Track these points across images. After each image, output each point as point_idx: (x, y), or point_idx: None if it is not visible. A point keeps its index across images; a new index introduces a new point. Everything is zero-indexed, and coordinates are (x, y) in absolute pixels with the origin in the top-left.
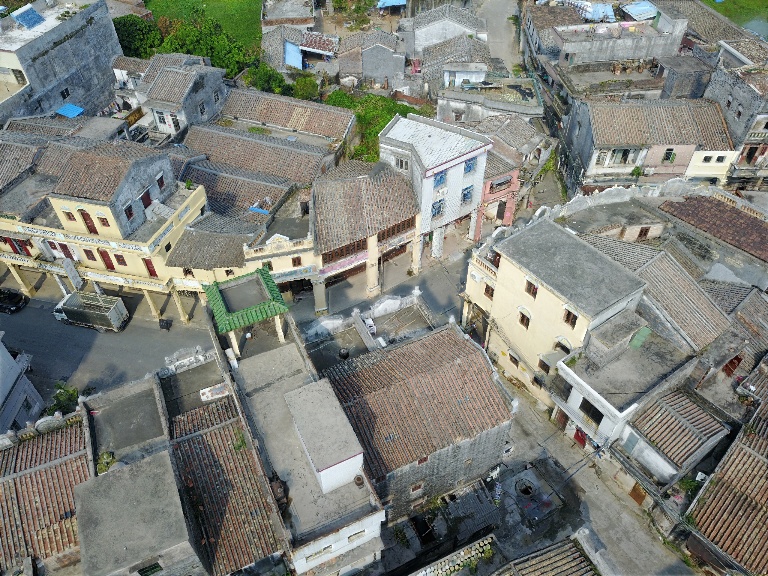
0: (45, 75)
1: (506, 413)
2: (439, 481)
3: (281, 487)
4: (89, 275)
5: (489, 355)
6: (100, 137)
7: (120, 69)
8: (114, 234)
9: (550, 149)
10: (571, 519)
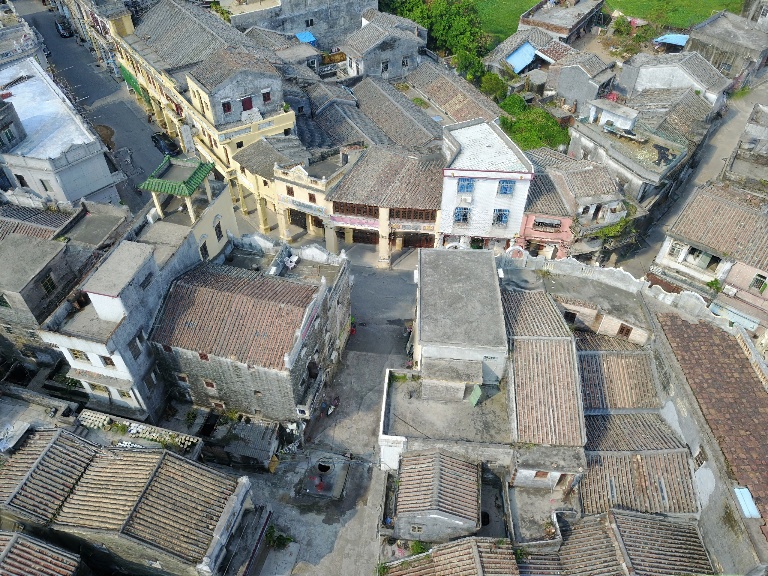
0: (297, 3)
1: (282, 364)
2: (232, 394)
3: (76, 294)
4: (198, 145)
5: (413, 360)
6: (291, 59)
7: (366, 19)
8: (211, 119)
9: (620, 215)
10: (332, 512)
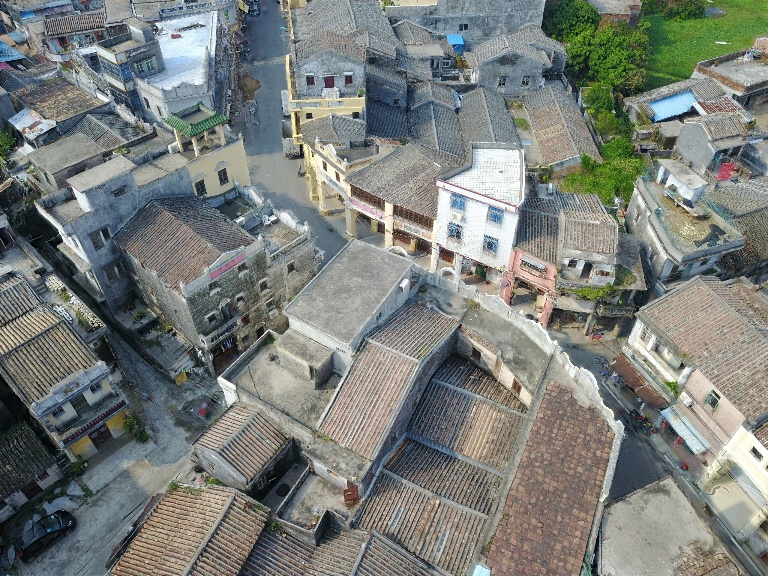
0: (454, 5)
1: None
2: None
3: None
4: None
5: None
6: (416, 54)
7: None
8: None
9: (606, 279)
10: (197, 434)
